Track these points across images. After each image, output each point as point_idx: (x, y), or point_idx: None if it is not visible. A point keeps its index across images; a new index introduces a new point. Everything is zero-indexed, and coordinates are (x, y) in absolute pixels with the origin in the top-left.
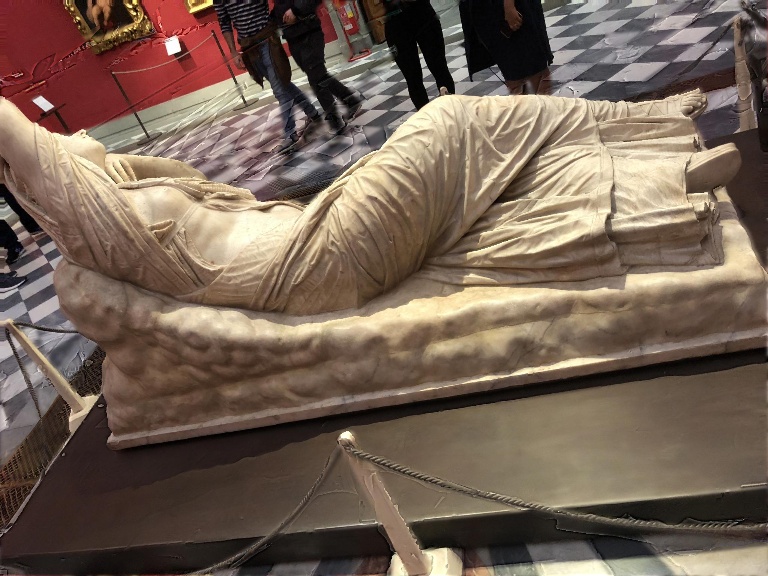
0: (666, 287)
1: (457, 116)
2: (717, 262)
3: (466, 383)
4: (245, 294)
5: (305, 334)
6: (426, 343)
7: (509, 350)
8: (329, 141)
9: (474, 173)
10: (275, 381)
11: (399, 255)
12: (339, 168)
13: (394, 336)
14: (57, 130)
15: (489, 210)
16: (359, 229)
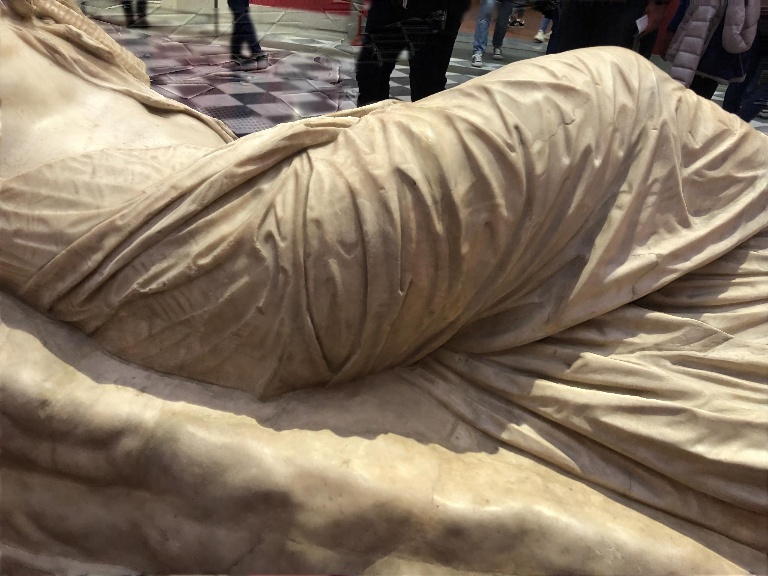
0: None
1: (640, 94)
2: None
3: None
4: (16, 262)
5: (112, 415)
6: (381, 550)
7: None
8: (305, 93)
9: (625, 225)
10: (0, 482)
11: (400, 325)
12: None
13: (316, 505)
14: None
15: (616, 312)
16: (344, 233)
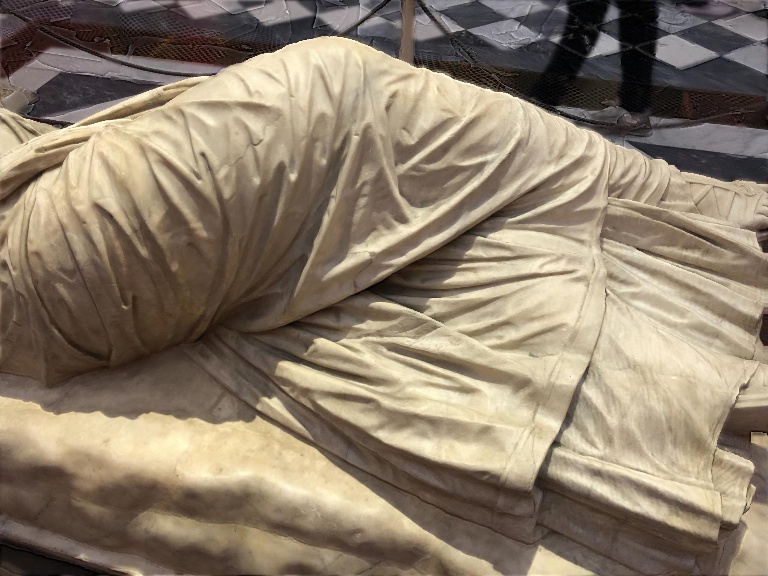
0: None
1: (344, 98)
2: None
3: None
4: None
5: None
6: (141, 507)
7: None
8: None
9: (339, 227)
10: None
11: (145, 325)
12: (255, 25)
13: (84, 475)
14: None
15: (346, 301)
16: (61, 262)
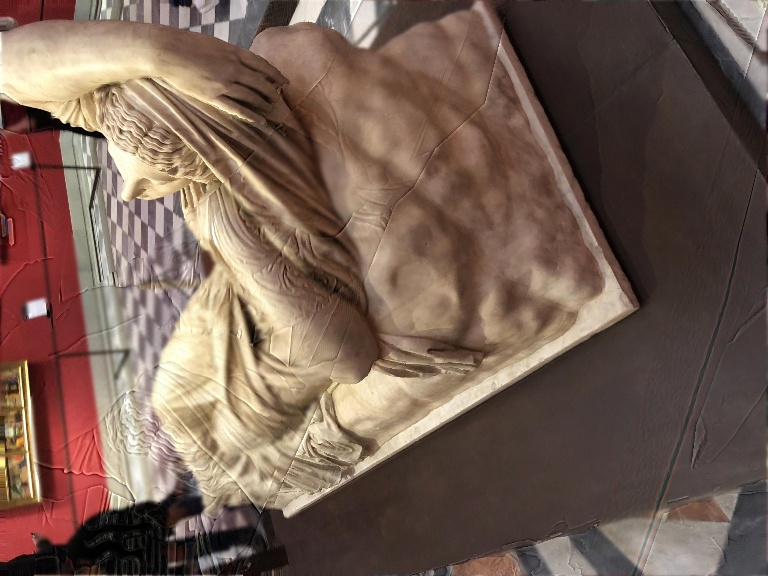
0: None
1: None
2: None
3: None
4: None
5: None
6: None
7: None
8: None
9: None
10: None
11: None
12: None
13: None
14: (604, 518)
15: None
16: None
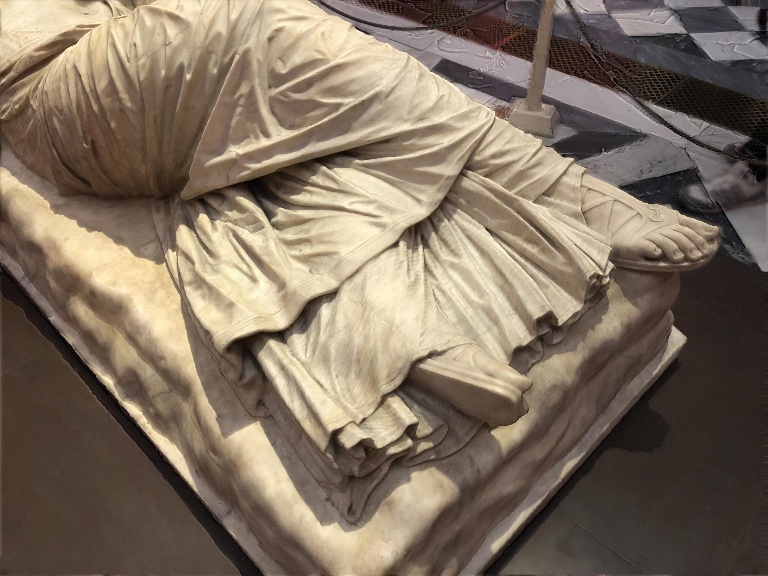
0: (255, 488)
1: (239, 23)
2: (350, 520)
3: (89, 367)
4: None
5: None
6: (73, 292)
7: (127, 376)
8: None
9: (221, 126)
10: None
11: (107, 167)
12: None
13: (51, 257)
14: None
15: (226, 191)
16: (57, 102)
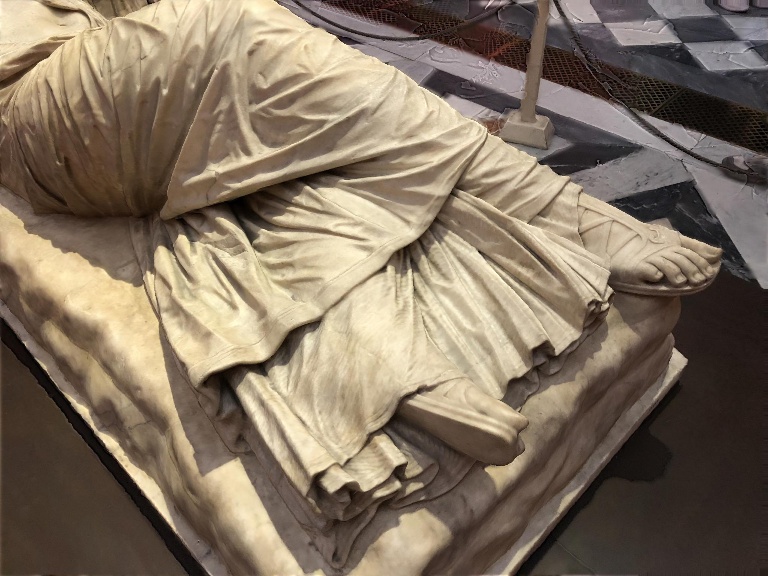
0: (233, 531)
1: (218, 36)
2: (335, 566)
3: (64, 395)
4: None
5: None
6: (47, 316)
7: (103, 405)
8: None
9: (200, 144)
10: None
11: (82, 185)
12: None
13: (24, 279)
14: None
15: (205, 211)
16: (28, 118)
